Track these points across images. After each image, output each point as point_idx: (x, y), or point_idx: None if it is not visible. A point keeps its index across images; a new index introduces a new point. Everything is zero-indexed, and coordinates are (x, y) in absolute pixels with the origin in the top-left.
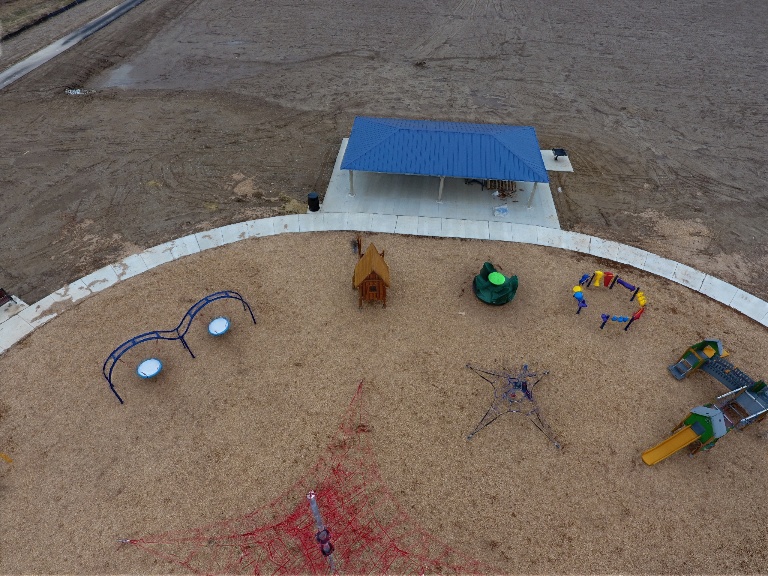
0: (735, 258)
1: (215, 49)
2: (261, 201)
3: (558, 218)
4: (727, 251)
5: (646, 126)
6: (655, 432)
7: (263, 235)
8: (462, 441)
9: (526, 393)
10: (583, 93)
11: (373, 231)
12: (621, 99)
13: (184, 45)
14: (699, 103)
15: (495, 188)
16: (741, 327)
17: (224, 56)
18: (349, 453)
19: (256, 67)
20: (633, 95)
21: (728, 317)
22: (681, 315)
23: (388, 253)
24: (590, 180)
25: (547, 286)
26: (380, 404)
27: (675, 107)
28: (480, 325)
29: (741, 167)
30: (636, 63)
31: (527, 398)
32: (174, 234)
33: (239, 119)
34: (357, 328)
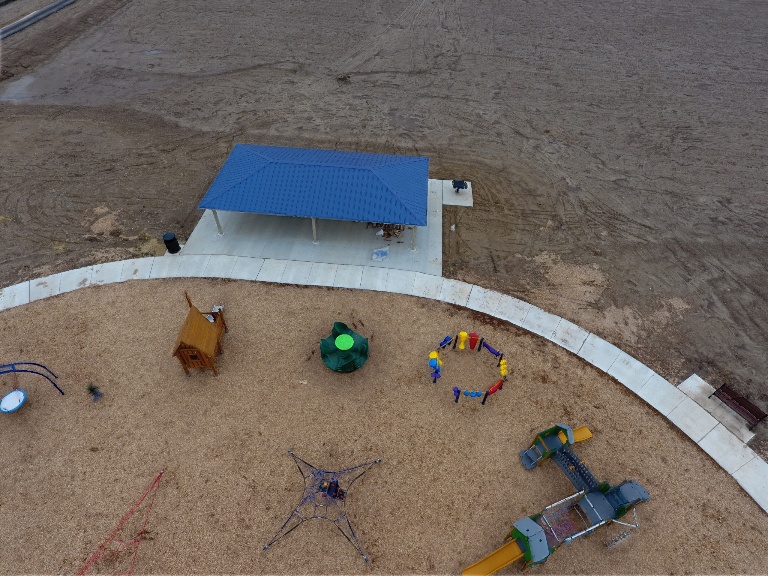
0: (626, 313)
1: (129, 59)
2: (118, 240)
3: (442, 263)
4: (619, 304)
5: (566, 152)
6: (486, 539)
7: (106, 282)
8: (256, 553)
9: (333, 496)
10: (508, 113)
11: (232, 278)
12: (547, 121)
13: (97, 54)
14: (629, 126)
15: (381, 226)
16: (614, 400)
17: (136, 67)
18: (118, 570)
19: (167, 80)
20: (561, 116)
21: (603, 387)
22: (550, 384)
23: (241, 305)
24: (489, 216)
25: (408, 347)
26: (175, 502)
27: (602, 130)
28: (320, 397)
29: (657, 201)
30: (572, 80)
31: (340, 499)
32: (6, 281)
33: (123, 142)
34: (177, 402)
